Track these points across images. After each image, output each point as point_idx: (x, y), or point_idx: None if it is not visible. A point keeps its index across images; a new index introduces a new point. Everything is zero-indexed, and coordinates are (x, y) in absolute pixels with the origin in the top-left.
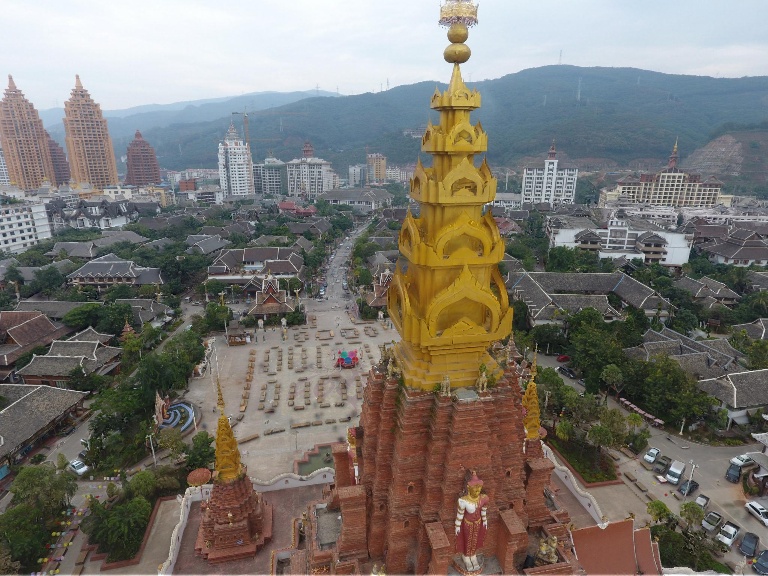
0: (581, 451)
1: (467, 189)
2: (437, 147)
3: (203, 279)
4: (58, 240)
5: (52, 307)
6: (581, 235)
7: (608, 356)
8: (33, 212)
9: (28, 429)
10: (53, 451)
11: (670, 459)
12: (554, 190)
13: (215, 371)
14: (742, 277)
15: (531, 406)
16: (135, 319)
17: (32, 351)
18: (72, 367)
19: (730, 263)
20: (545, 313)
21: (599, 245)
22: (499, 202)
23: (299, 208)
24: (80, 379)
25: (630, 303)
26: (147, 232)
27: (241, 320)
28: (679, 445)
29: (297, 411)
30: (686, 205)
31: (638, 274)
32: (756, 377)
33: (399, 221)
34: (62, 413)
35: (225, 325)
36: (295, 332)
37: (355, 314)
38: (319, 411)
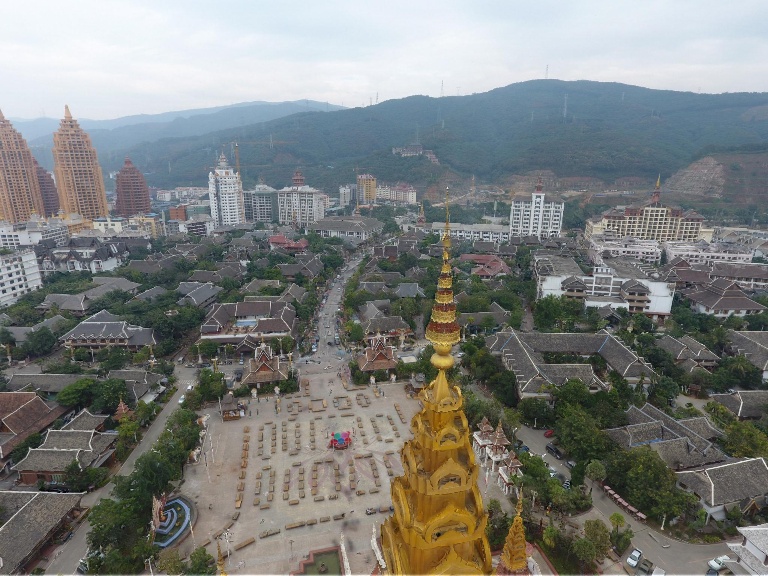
0: (567, 556)
1: (452, 482)
2: (425, 447)
3: (196, 339)
4: (49, 291)
5: (45, 380)
6: (567, 283)
7: (593, 443)
8: (23, 261)
9: (26, 545)
10: (51, 563)
11: (651, 563)
12: (541, 222)
13: (210, 455)
14: (721, 338)
15: (517, 540)
16: (129, 396)
17: (27, 440)
18: (68, 461)
19: (711, 313)
20: (532, 385)
21: (585, 293)
22: (488, 233)
23: (290, 242)
24: (76, 475)
25: (614, 368)
26: (138, 276)
27: (235, 389)
28: (660, 543)
29: (292, 506)
30: (669, 239)
31: (622, 332)
32: (732, 471)
33: (390, 258)
34: (60, 520)
35: (219, 402)
36: (288, 402)
37: (347, 377)
38: (313, 506)
